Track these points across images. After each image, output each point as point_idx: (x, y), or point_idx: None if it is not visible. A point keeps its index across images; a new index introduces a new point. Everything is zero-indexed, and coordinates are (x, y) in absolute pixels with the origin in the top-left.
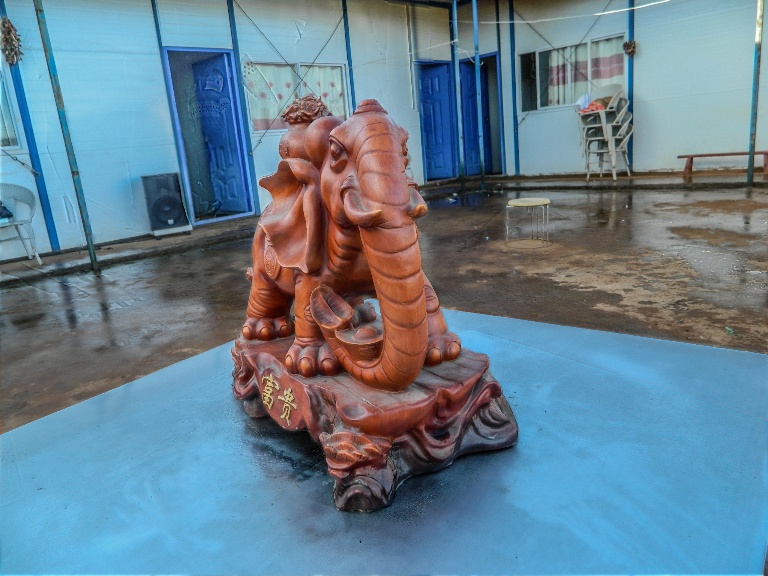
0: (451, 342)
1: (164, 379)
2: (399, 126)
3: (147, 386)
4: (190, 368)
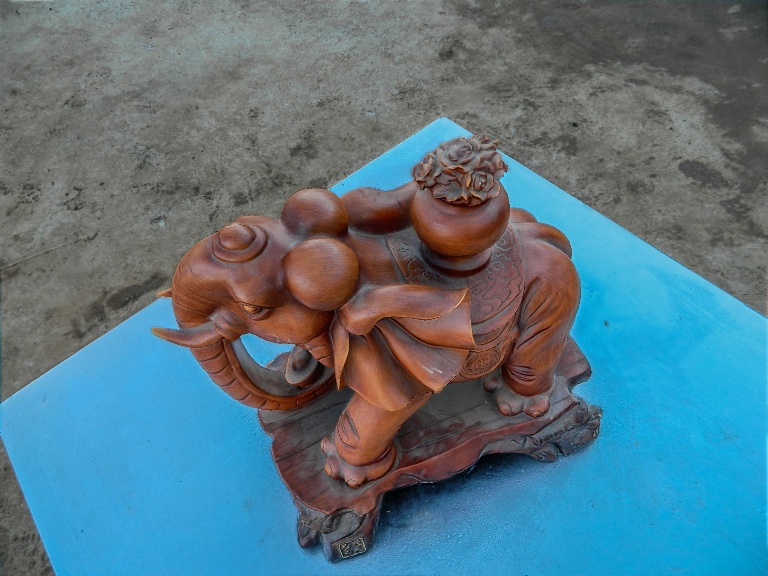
0: (329, 463)
1: (576, 230)
2: (233, 285)
3: (562, 219)
4: (603, 248)
